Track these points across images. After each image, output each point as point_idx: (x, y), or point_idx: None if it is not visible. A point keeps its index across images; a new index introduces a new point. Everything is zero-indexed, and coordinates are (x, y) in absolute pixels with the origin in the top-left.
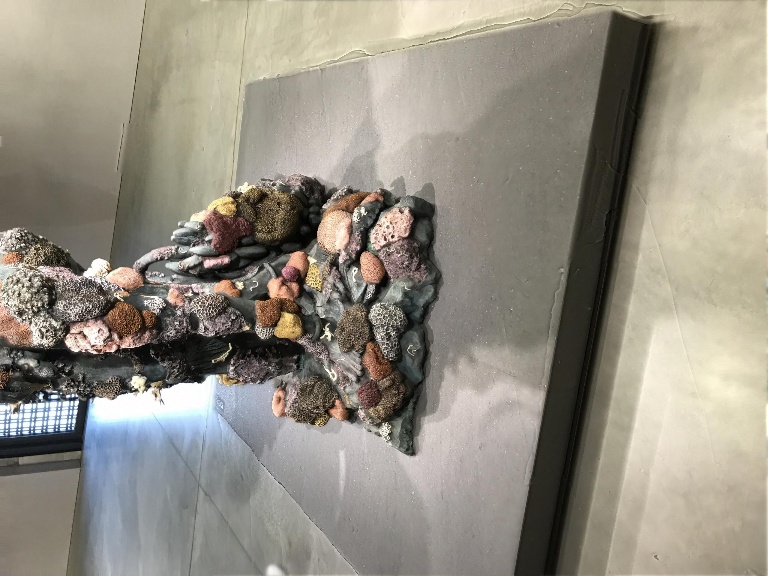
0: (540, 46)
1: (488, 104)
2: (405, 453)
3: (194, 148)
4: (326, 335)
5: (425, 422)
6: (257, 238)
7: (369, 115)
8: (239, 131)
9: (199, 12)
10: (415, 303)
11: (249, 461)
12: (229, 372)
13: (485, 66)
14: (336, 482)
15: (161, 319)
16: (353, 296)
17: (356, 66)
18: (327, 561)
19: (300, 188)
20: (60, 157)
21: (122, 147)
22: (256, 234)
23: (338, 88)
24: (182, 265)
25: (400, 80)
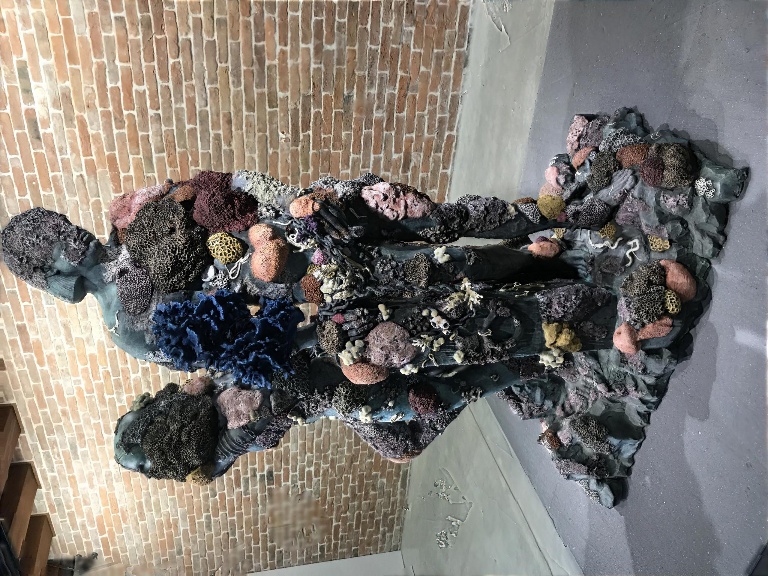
0: (562, 2)
1: (569, 51)
2: (738, 176)
3: None
4: None
5: (722, 145)
6: None
7: None
8: None
9: None
10: None
11: None
12: (538, 298)
13: (556, 55)
14: (766, 365)
15: None
16: None
17: None
18: None
19: None
20: None
21: None
22: None
23: None
24: None
25: (537, 152)
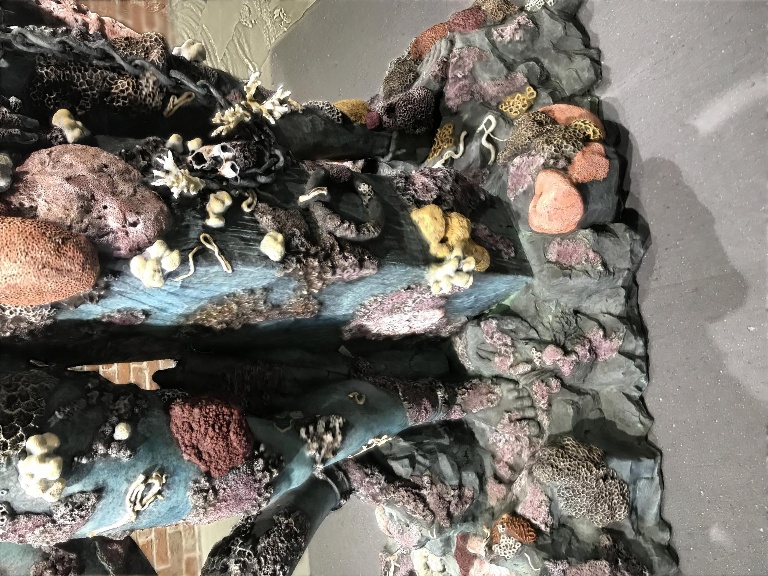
0: None
1: None
2: None
3: None
4: None
5: None
6: None
7: None
8: None
9: None
10: None
11: None
12: None
13: None
14: None
15: None
16: None
17: None
18: None
19: None
20: None
21: None
22: None
23: None
24: None
25: None
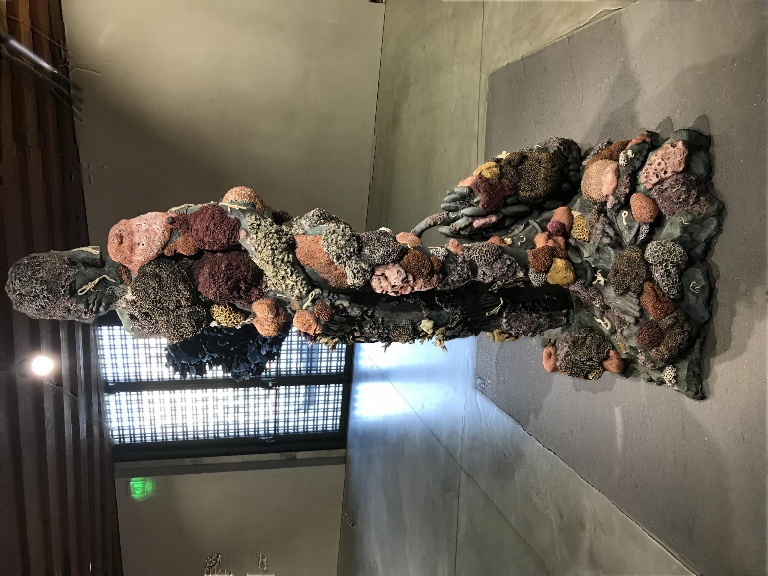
0: None
1: None
2: (694, 397)
3: (437, 151)
4: (599, 280)
5: (715, 362)
6: (521, 197)
7: (625, 66)
8: (482, 124)
9: (435, 26)
10: (695, 239)
11: (512, 439)
12: (502, 324)
13: None
14: (613, 440)
15: (445, 265)
16: (625, 239)
17: (607, 23)
18: (605, 530)
19: (558, 148)
20: (326, 171)
21: (376, 157)
22: (520, 193)
23: (588, 50)
24: (454, 227)
25: (659, 22)
